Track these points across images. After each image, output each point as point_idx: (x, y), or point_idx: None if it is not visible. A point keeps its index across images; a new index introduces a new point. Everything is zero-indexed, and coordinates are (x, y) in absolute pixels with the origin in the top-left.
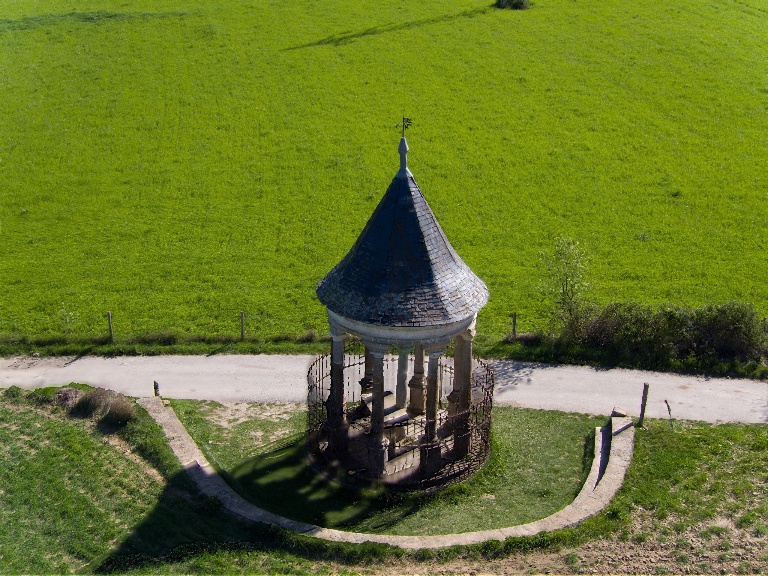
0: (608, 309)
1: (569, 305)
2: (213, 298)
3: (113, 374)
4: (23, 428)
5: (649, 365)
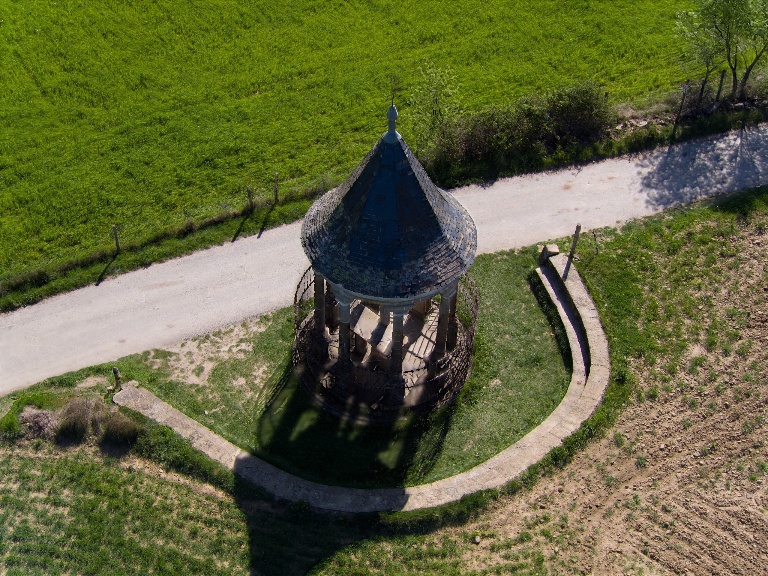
0: (473, 120)
1: (442, 129)
2: (36, 195)
3: (14, 346)
4: (25, 484)
5: (525, 168)
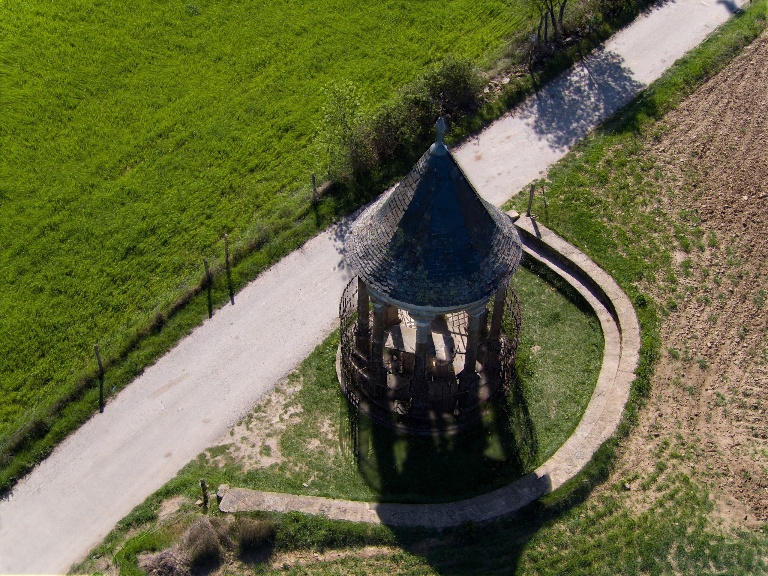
0: (372, 124)
1: (354, 141)
2: None
3: (57, 507)
4: None
5: None
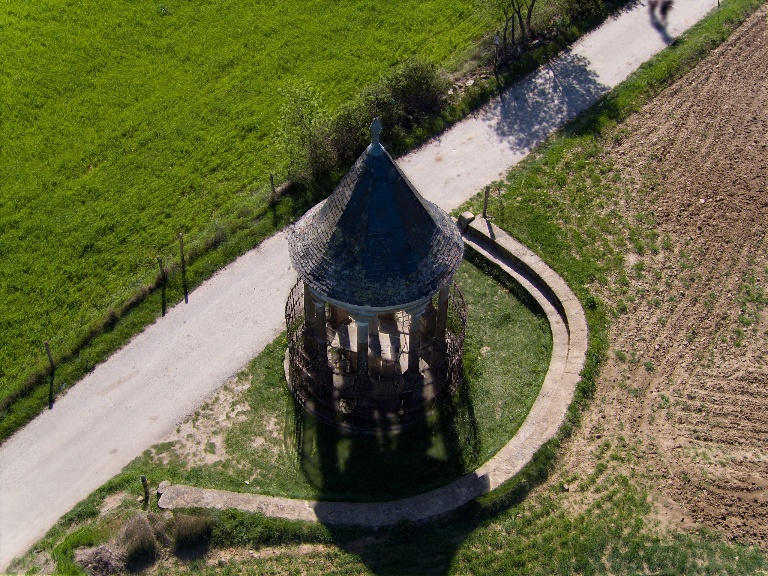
0: (332, 125)
1: (313, 141)
2: None
3: (1, 502)
4: None
5: (394, 155)
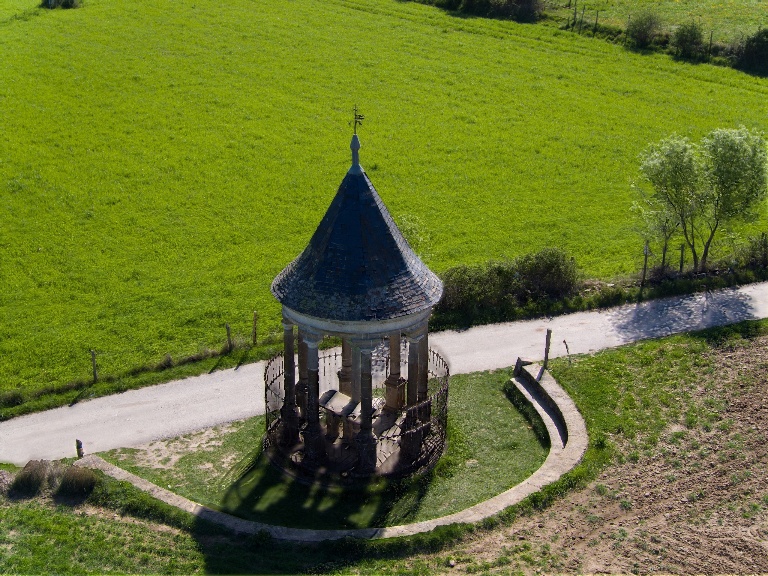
0: (445, 275)
1: None
2: (20, 347)
3: None
4: None
5: (498, 318)
